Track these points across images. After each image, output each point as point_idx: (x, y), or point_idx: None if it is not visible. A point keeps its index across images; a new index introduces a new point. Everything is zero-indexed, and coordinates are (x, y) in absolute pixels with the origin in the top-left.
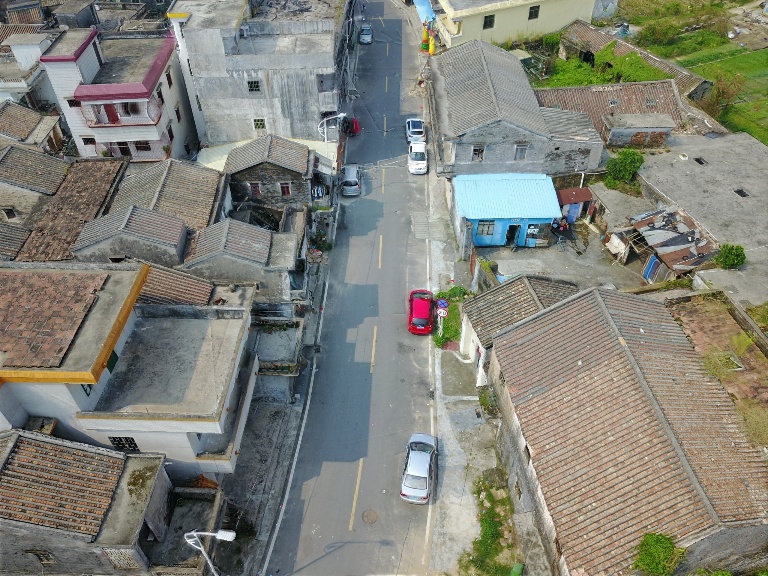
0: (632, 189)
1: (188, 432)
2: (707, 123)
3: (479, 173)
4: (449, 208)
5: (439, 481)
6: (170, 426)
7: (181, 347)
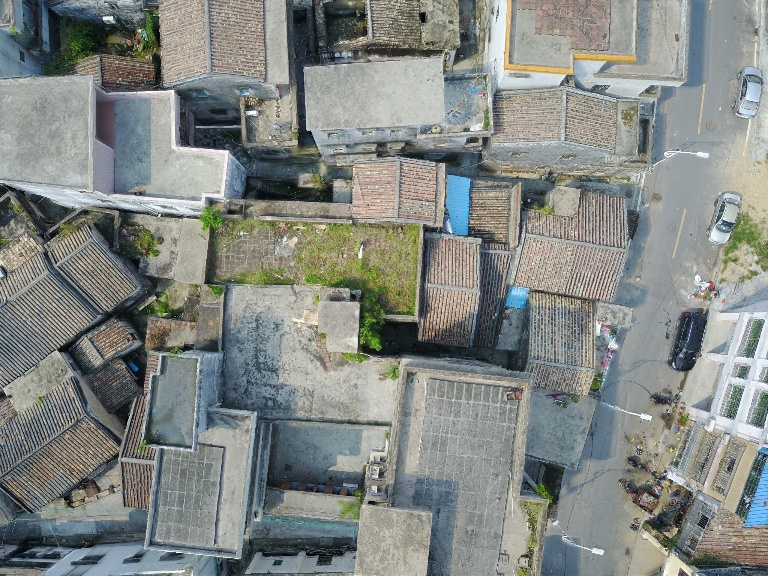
0: None
1: None
2: None
3: None
4: None
5: None
6: None
7: None
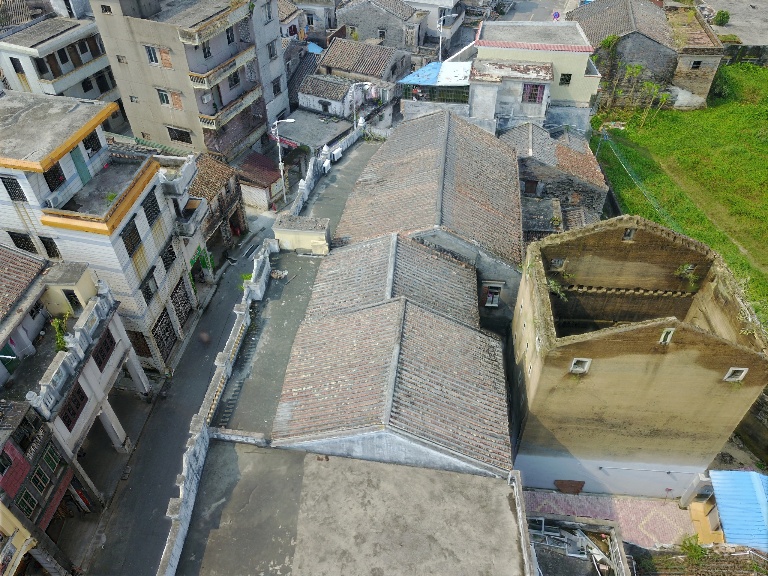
0: (688, 2)
1: (439, 7)
2: None
3: None
4: None
5: None
6: (434, 0)
7: None
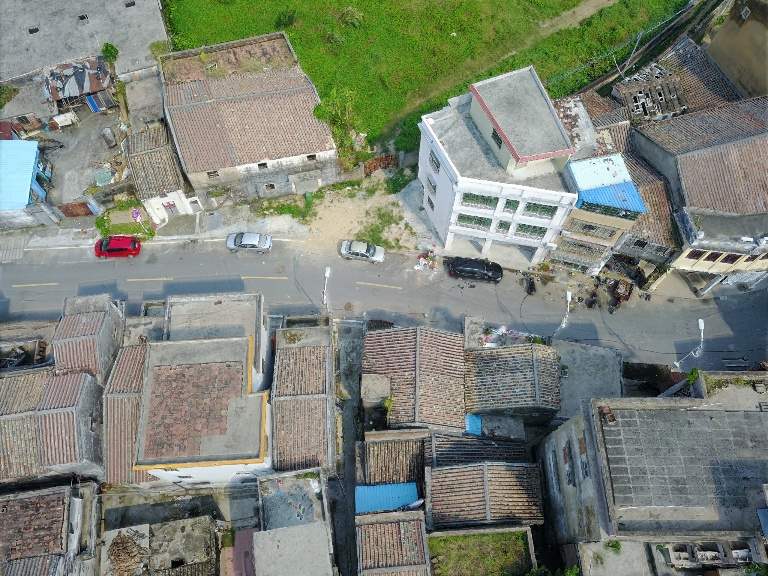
0: (8, 93)
1: None
2: None
3: None
4: None
5: None
6: None
7: None
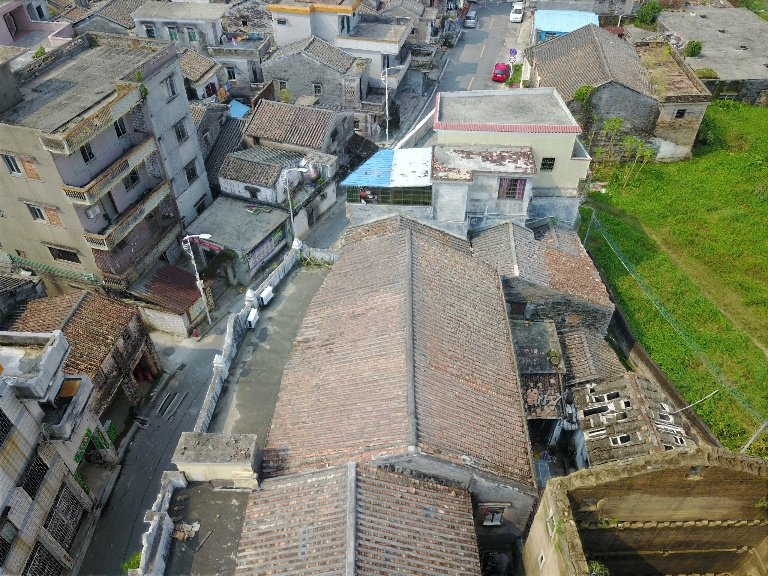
0: (651, 28)
1: (382, 54)
2: (722, 2)
3: (552, 9)
4: None
5: None
6: (376, 46)
7: (379, 30)
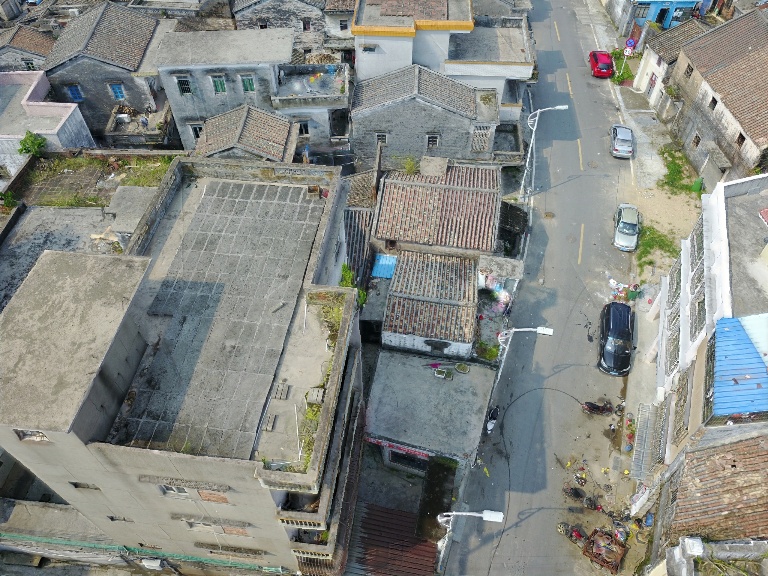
0: None
1: (507, 79)
2: None
3: None
4: (605, 4)
5: (634, 149)
6: (501, 71)
7: (485, 40)
